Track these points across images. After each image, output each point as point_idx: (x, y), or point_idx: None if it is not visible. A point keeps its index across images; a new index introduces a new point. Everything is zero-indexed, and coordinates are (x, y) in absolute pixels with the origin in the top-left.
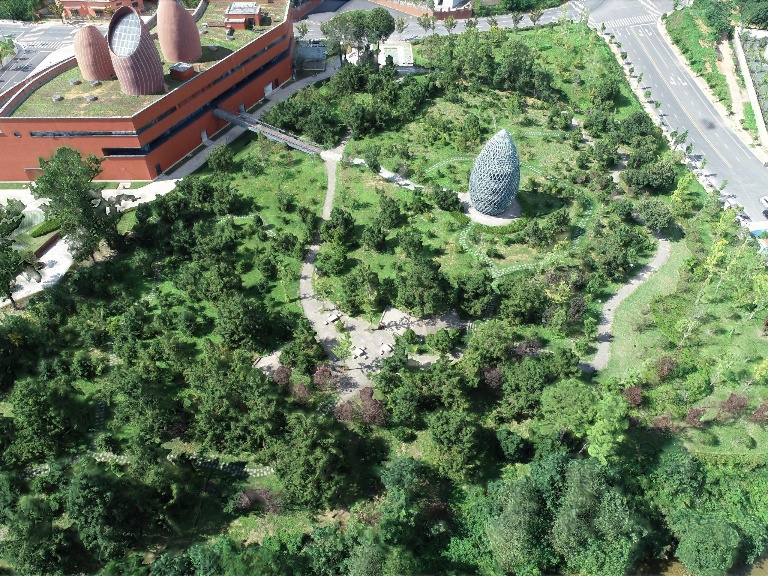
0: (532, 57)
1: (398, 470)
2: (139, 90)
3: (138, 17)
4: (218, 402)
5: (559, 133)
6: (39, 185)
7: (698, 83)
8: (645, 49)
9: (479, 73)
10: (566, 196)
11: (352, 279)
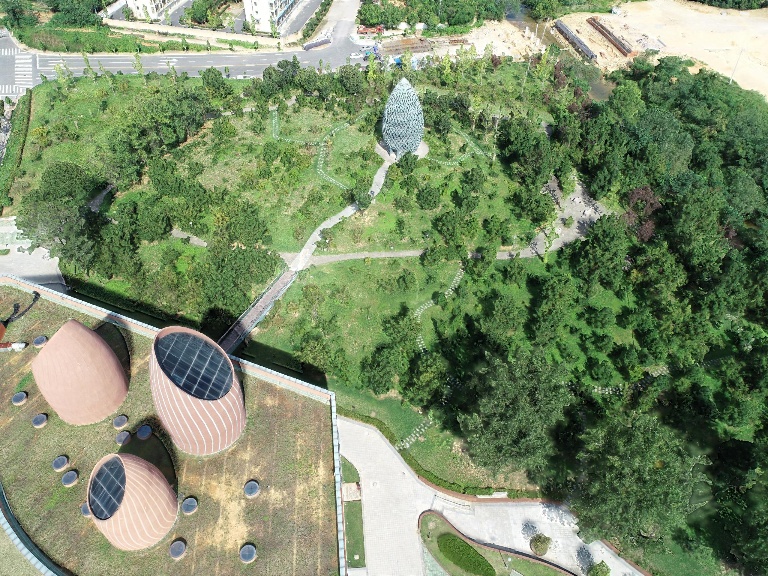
0: (191, 89)
1: (685, 176)
2: (244, 409)
3: (181, 327)
4: (701, 246)
5: (272, 116)
6: (558, 412)
7: (175, 54)
8: (96, 67)
9: (167, 141)
10: (379, 116)
11: (537, 202)
